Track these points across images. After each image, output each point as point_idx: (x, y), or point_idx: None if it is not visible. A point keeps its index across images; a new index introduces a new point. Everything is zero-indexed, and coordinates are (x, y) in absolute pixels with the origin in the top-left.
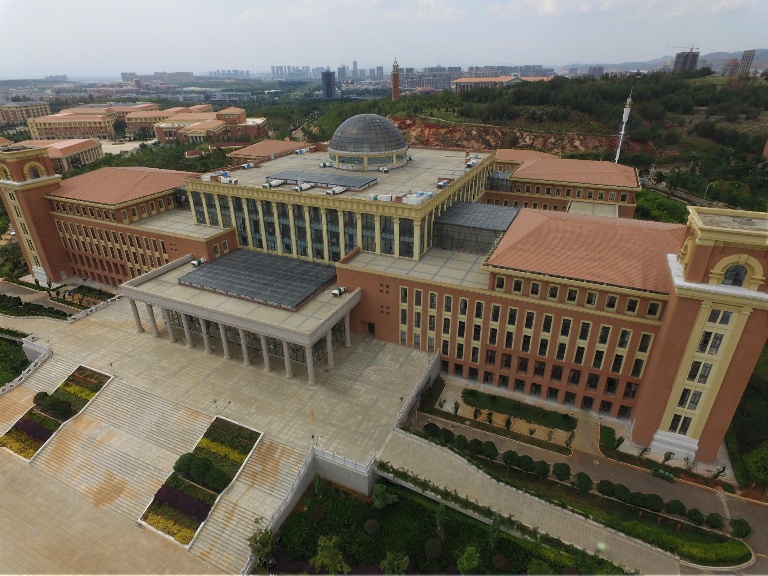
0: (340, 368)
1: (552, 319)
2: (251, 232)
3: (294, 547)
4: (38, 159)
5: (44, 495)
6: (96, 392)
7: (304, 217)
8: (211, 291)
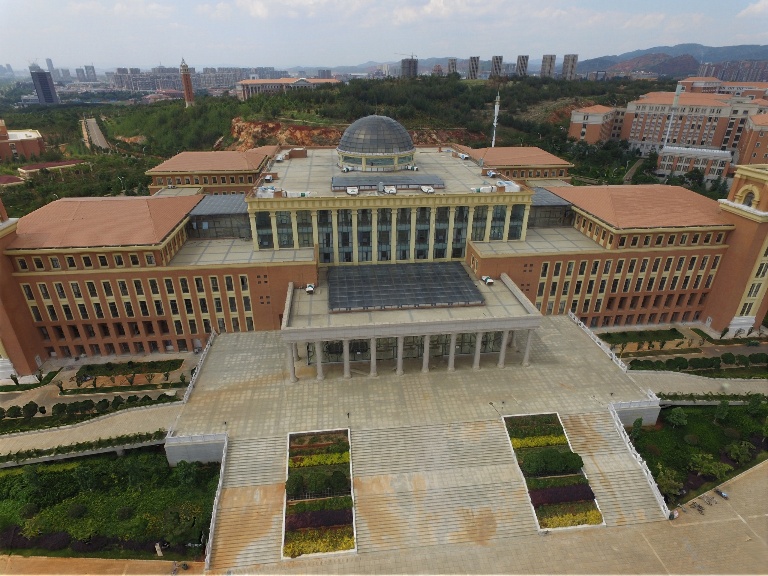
0: (524, 346)
1: (660, 260)
2: (338, 246)
3: None
4: None
5: (422, 567)
6: (348, 451)
7: (408, 220)
8: (379, 310)
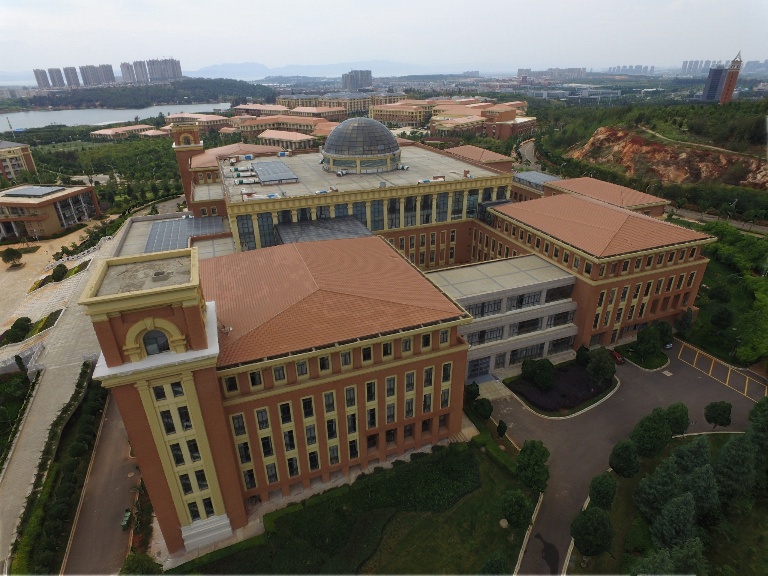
0: None
1: None
2: None
3: None
4: (191, 132)
5: (5, 311)
6: (74, 274)
7: None
8: None
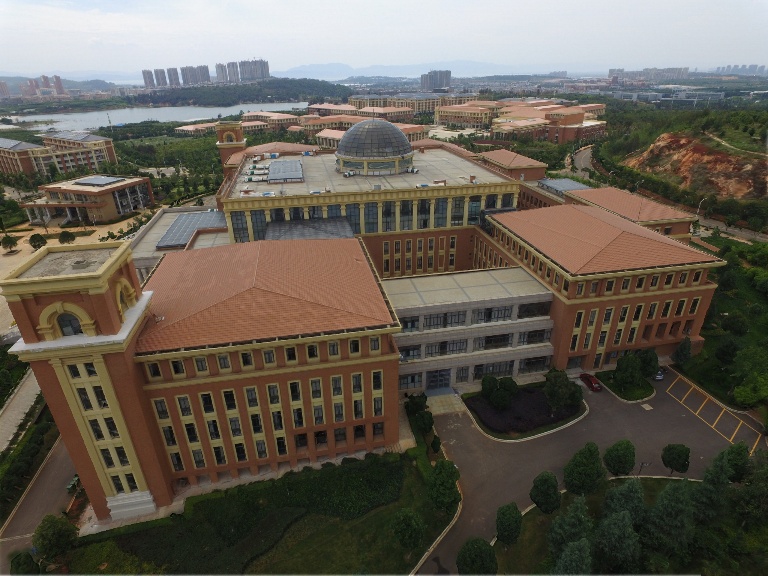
0: None
1: None
2: None
3: (1, 350)
4: (234, 130)
5: None
6: None
7: None
8: None
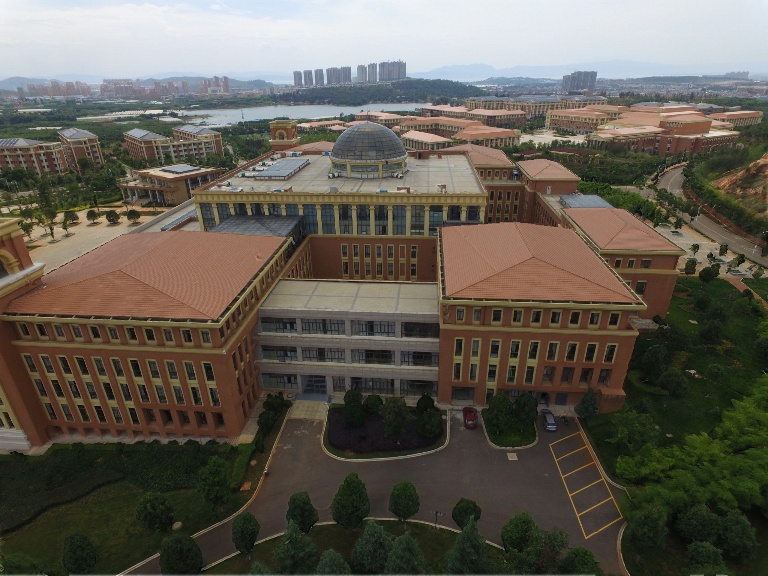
0: None
1: None
2: None
3: None
4: (285, 129)
5: None
6: None
7: None
8: None
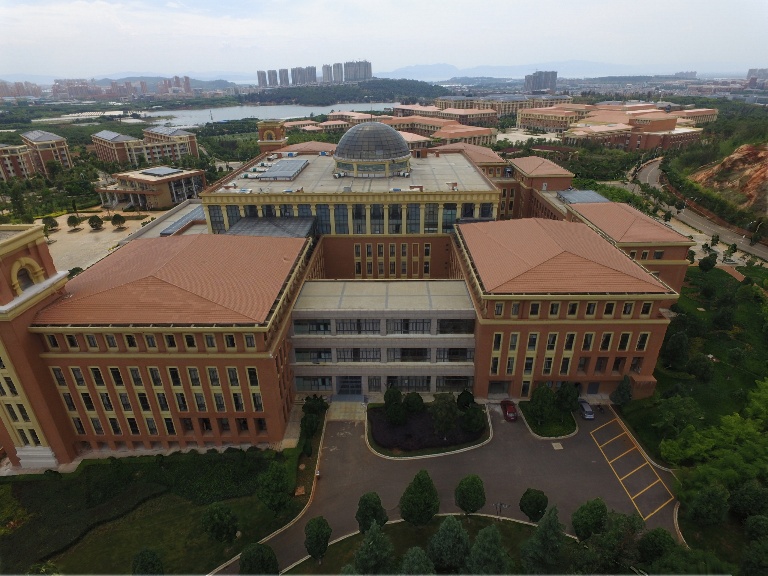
0: None
1: None
2: None
3: None
4: (274, 129)
5: None
6: None
7: None
8: None
